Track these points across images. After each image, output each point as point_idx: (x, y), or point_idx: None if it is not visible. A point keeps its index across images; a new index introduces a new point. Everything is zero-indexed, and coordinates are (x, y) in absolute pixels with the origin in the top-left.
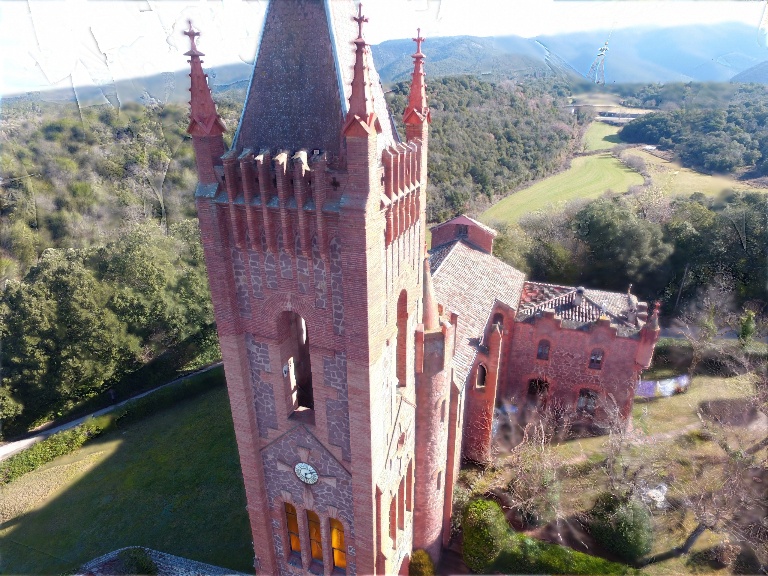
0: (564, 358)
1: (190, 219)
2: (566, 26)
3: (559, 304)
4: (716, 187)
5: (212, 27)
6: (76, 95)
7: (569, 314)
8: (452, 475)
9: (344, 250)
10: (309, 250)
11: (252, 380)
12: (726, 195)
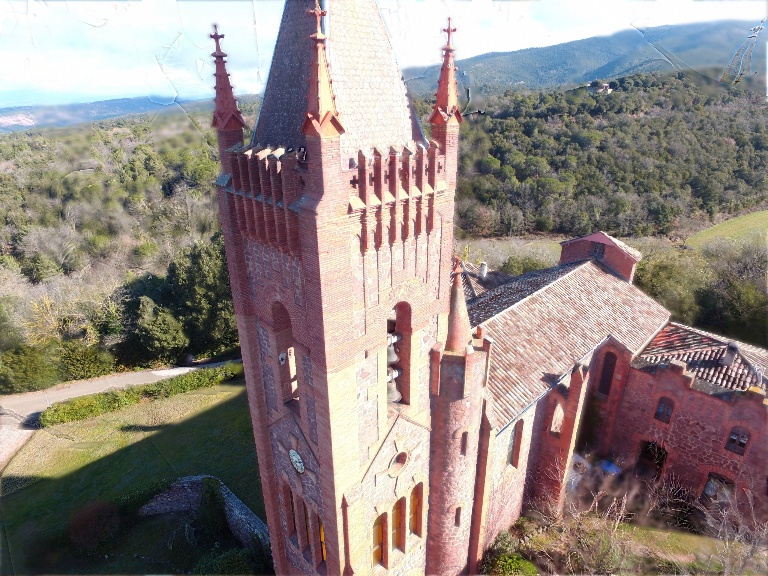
0: (691, 427)
1: None
2: (715, 1)
3: (699, 358)
4: None
5: None
6: None
7: (709, 374)
8: (480, 516)
9: (304, 250)
10: (286, 246)
11: (261, 360)
12: None
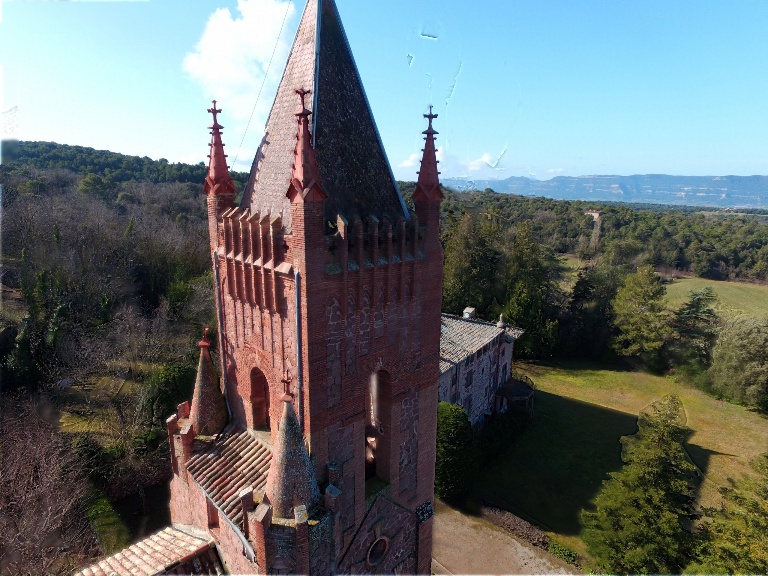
0: None
1: None
2: None
3: None
4: None
5: None
6: None
7: None
8: None
9: None
10: None
11: None
12: None
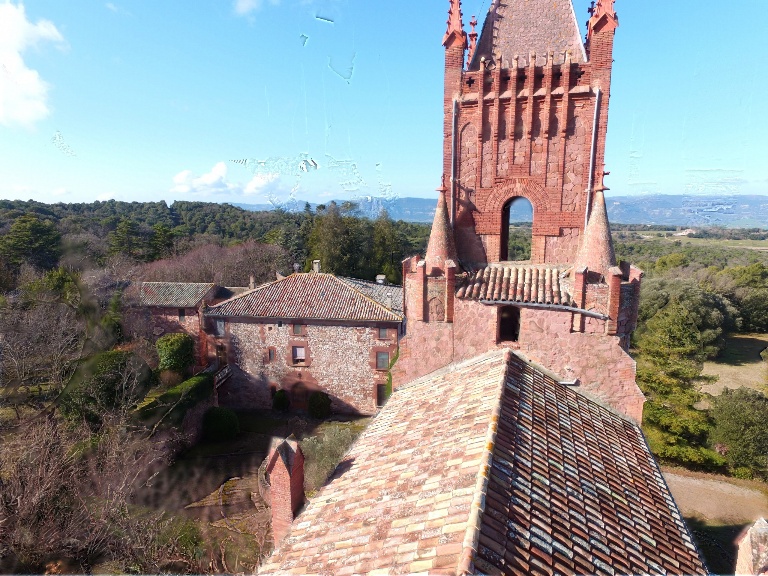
0: None
1: None
2: None
3: None
4: (23, 110)
5: None
6: None
7: None
8: None
9: None
10: None
11: None
12: (49, 122)
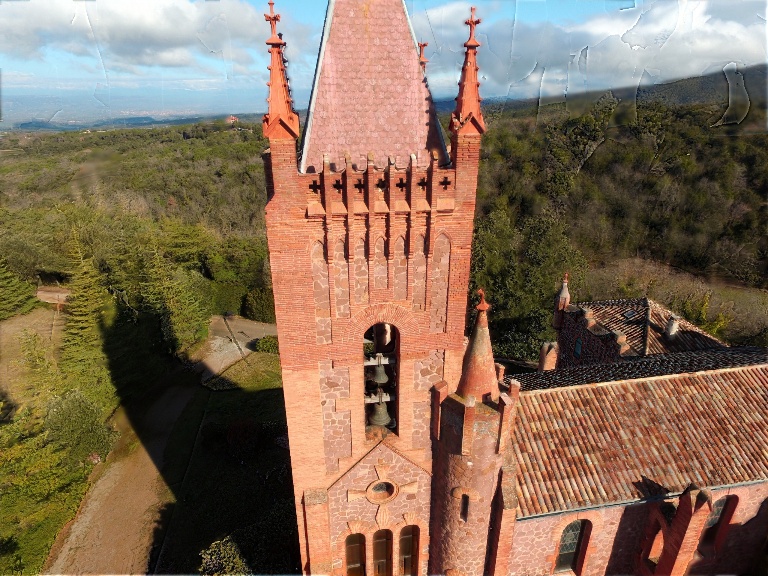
0: None
1: (588, 222)
2: None
3: None
4: None
5: (693, 16)
6: (541, 94)
7: None
8: None
9: None
10: None
11: None
12: None
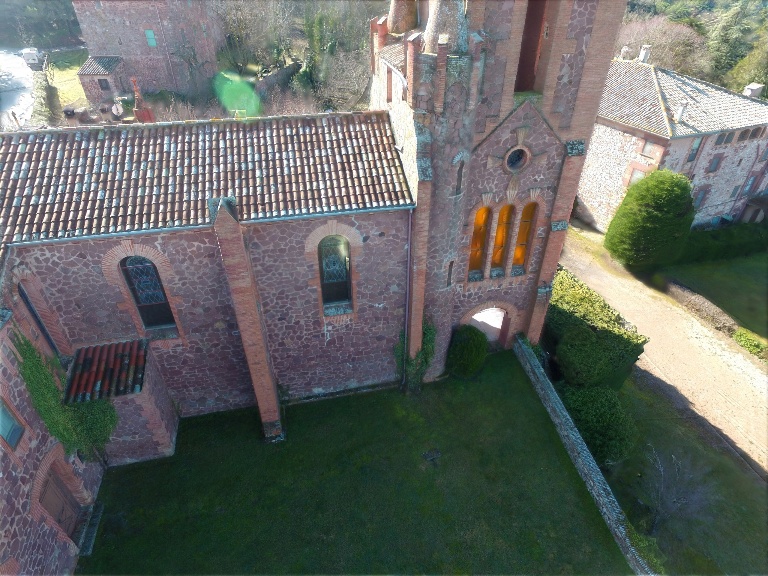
0: None
1: None
2: None
3: None
4: None
5: None
6: None
7: None
8: None
9: None
10: None
11: None
12: None
